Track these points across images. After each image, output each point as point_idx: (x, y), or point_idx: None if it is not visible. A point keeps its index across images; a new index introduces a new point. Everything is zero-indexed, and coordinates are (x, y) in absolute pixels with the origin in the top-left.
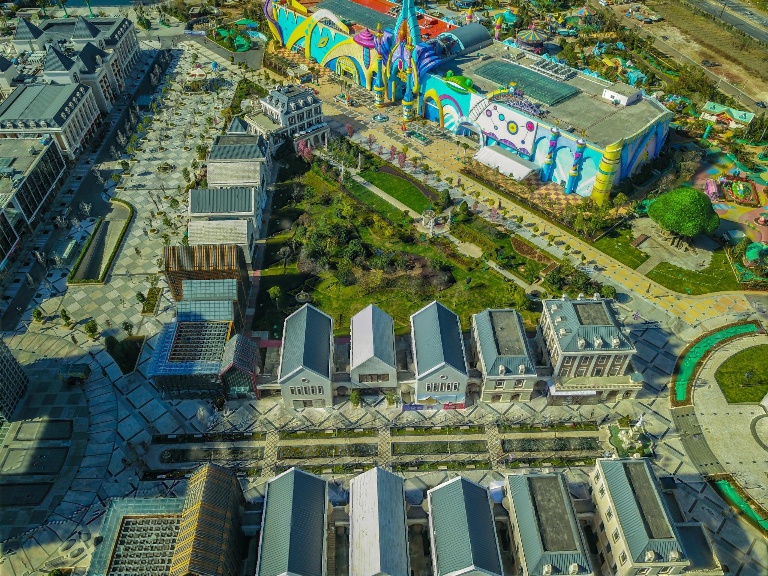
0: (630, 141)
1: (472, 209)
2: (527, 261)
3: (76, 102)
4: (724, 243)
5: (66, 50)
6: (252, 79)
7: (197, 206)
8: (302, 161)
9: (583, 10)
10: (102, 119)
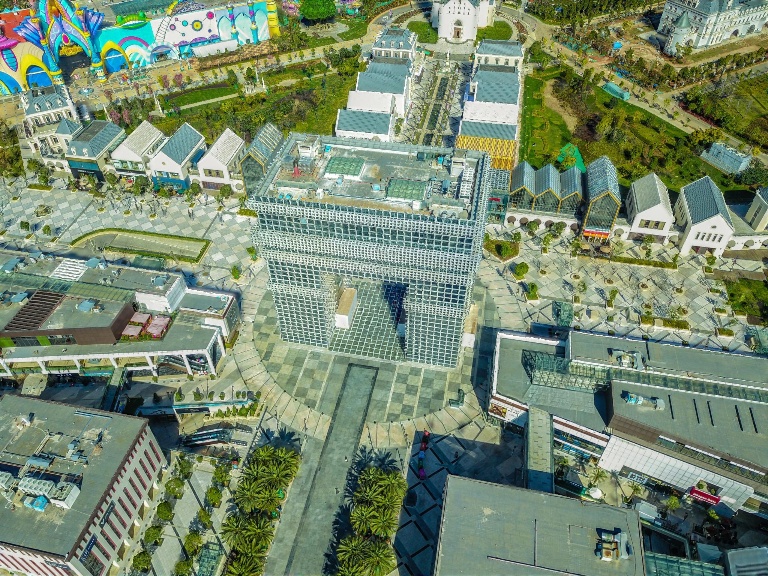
0: None
1: None
2: None
3: None
4: (335, 16)
5: None
6: None
7: (176, 158)
8: None
9: None
10: None
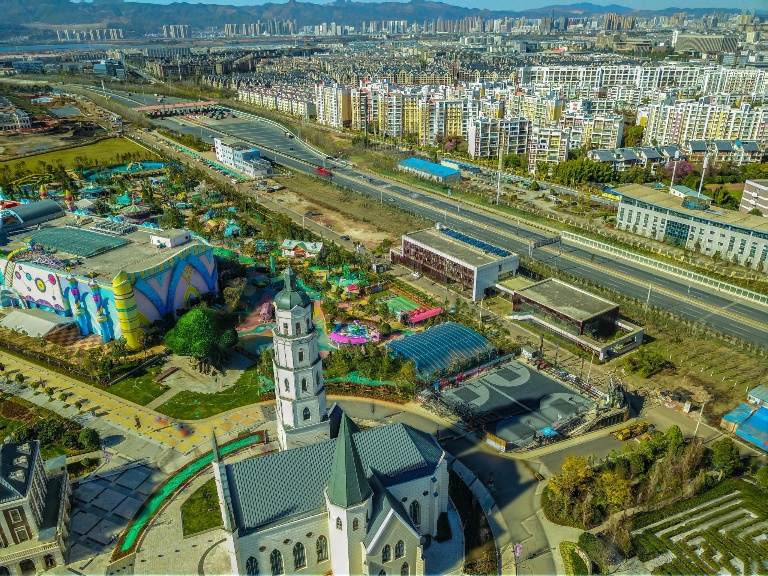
0: (146, 275)
1: None
2: (9, 424)
3: None
4: (257, 359)
5: None
6: None
7: None
8: None
9: (201, 186)
10: None
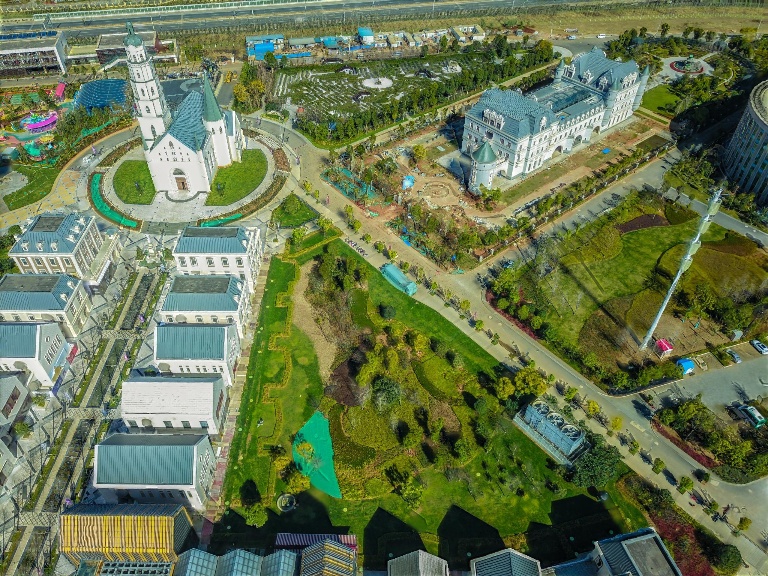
0: None
1: None
2: None
3: None
4: (10, 161)
5: None
6: None
7: None
8: None
9: None
10: None
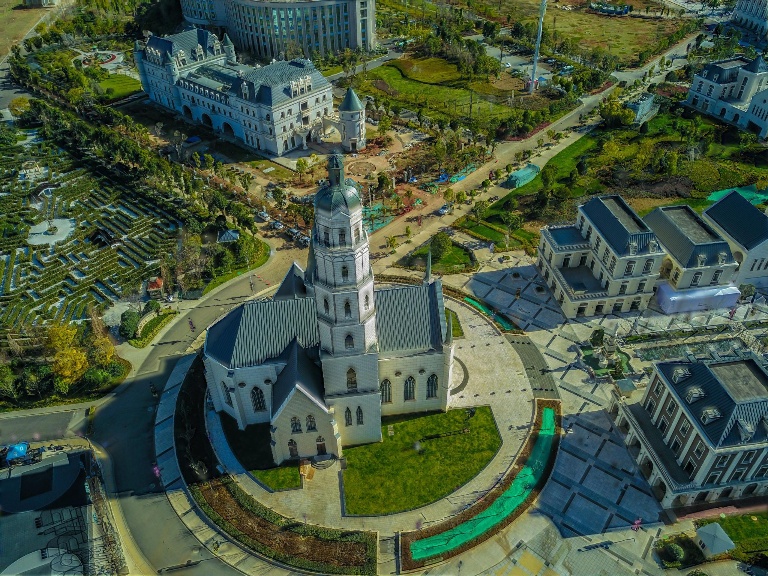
0: None
1: None
2: None
3: None
4: None
5: None
6: None
7: None
8: None
9: None
10: None
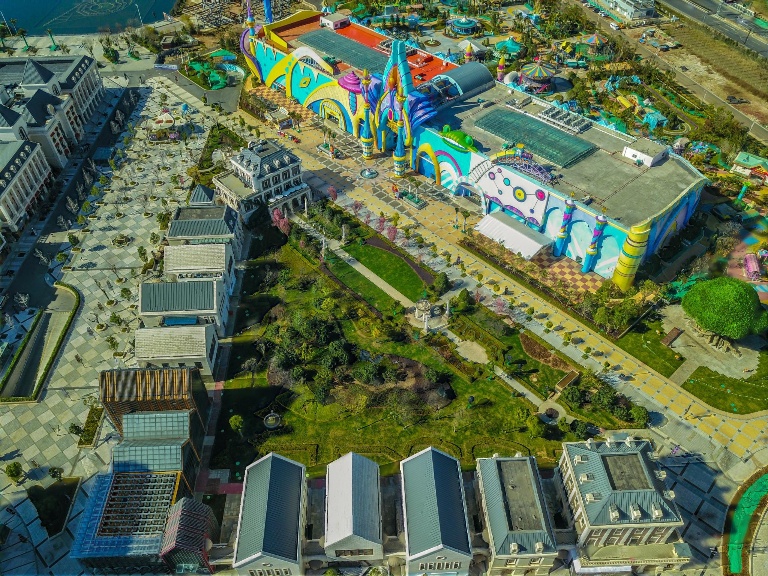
0: (659, 218)
1: (474, 294)
2: (540, 367)
3: (19, 164)
4: None
5: (16, 96)
6: (226, 125)
7: (149, 303)
8: (278, 230)
9: (593, 38)
10: (54, 177)
